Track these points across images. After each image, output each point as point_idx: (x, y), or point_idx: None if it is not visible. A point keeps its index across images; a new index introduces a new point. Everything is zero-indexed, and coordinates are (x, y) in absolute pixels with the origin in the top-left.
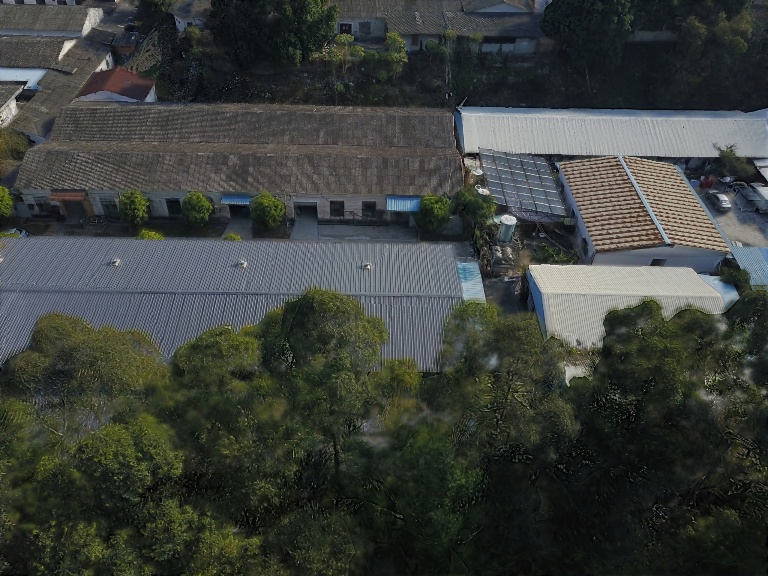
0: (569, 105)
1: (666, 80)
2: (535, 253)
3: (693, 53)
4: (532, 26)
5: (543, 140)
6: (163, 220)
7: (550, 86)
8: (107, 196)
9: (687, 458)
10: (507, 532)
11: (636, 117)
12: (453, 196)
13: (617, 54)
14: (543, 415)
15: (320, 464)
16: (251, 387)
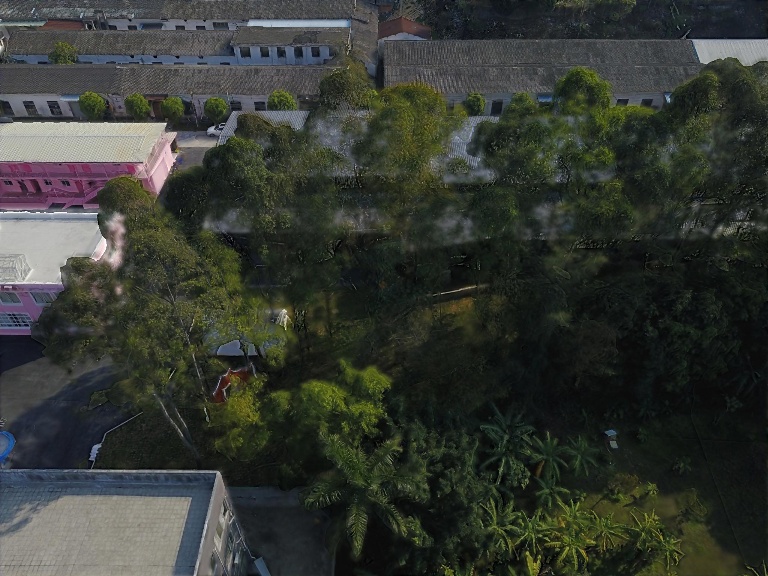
0: (765, 37)
1: None
2: None
3: None
4: None
5: (762, 58)
6: None
7: (746, 23)
8: (450, 99)
9: None
10: None
11: None
12: None
13: None
14: None
15: None
16: None
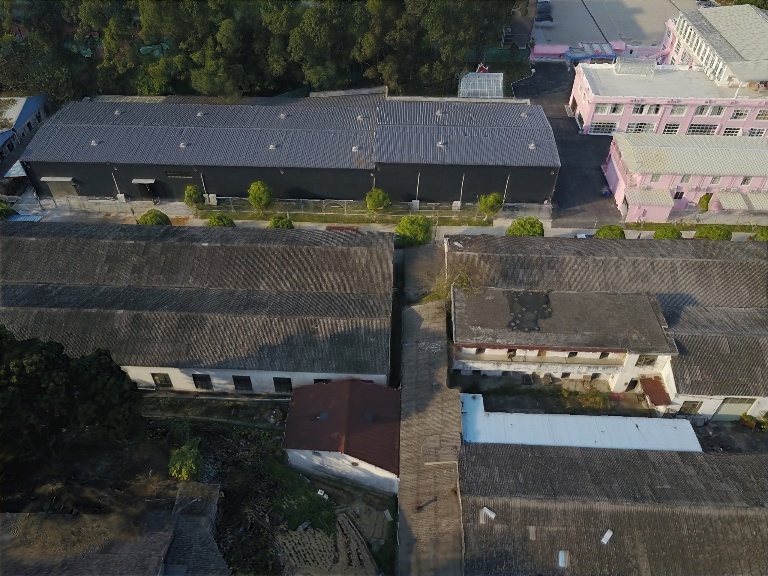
0: None
1: None
2: None
3: None
4: None
5: None
6: None
7: None
8: None
9: None
10: None
11: None
12: None
13: None
14: None
15: None
16: None
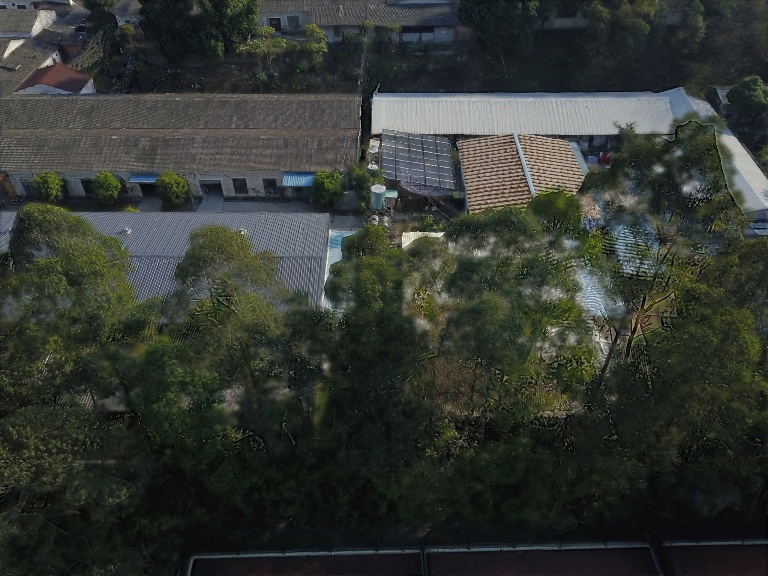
0: (485, 90)
1: (582, 64)
2: (418, 223)
3: (601, 36)
4: (450, 15)
5: (448, 121)
6: (81, 200)
7: (468, 72)
8: (26, 177)
9: (383, 358)
10: (304, 454)
11: (541, 98)
12: (346, 172)
13: (528, 39)
14: (248, 318)
15: (95, 376)
16: (16, 302)
